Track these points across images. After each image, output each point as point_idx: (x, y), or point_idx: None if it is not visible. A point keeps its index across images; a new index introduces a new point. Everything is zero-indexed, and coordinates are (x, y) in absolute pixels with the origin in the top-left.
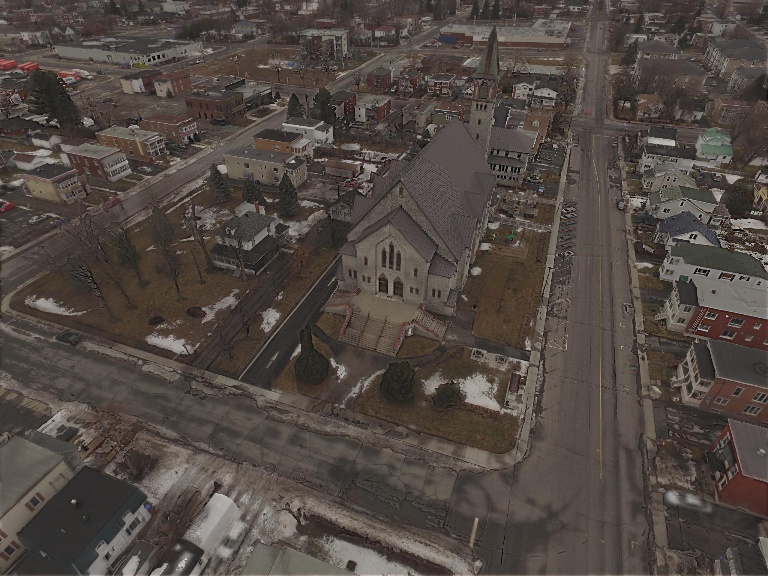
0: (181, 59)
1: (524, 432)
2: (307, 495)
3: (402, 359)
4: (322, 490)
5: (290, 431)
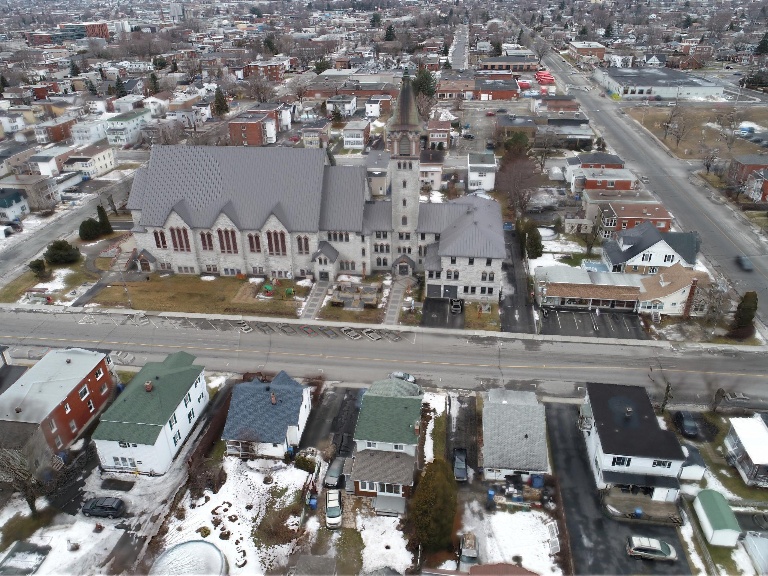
0: (666, 99)
1: (0, 305)
2: (2, 250)
3: (94, 259)
4: (2, 253)
5: (49, 240)
